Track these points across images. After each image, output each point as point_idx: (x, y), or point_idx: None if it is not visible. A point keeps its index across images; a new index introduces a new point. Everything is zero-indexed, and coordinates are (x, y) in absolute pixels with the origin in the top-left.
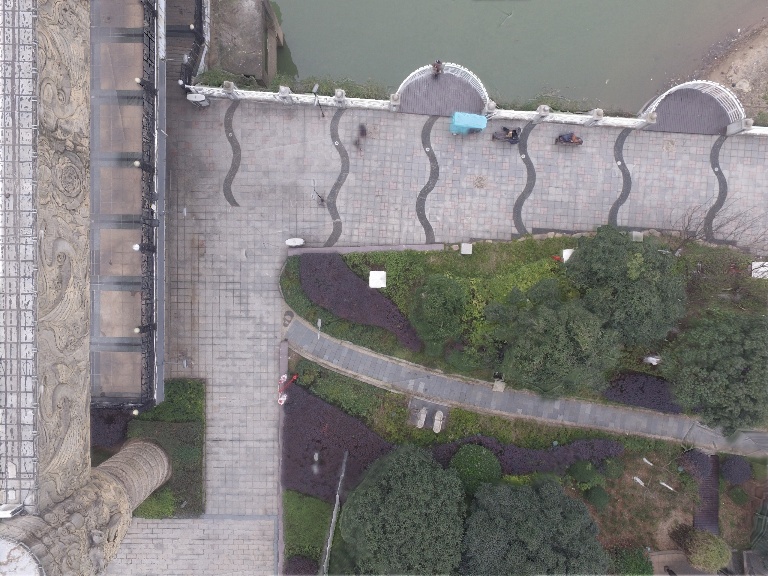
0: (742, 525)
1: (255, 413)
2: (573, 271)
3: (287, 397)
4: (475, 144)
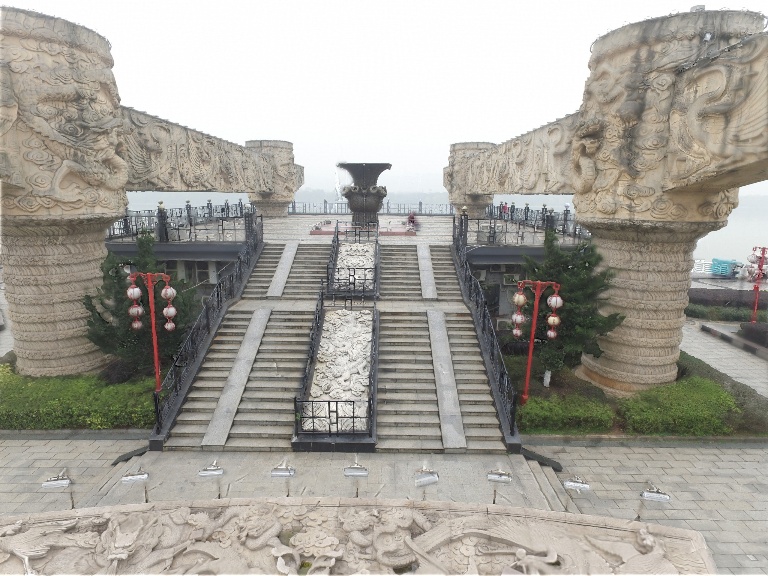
0: None
1: (735, 362)
2: None
3: (765, 328)
4: (740, 283)
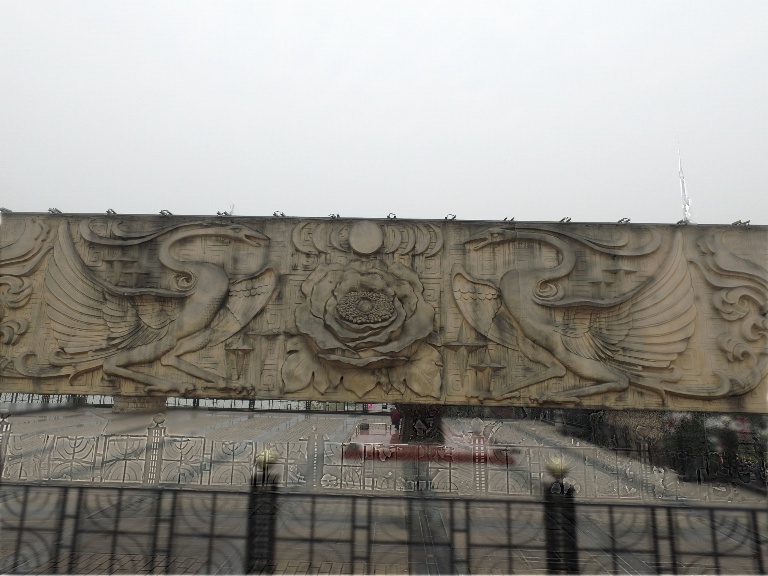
0: (578, 434)
1: None
2: (433, 408)
3: None
4: None
